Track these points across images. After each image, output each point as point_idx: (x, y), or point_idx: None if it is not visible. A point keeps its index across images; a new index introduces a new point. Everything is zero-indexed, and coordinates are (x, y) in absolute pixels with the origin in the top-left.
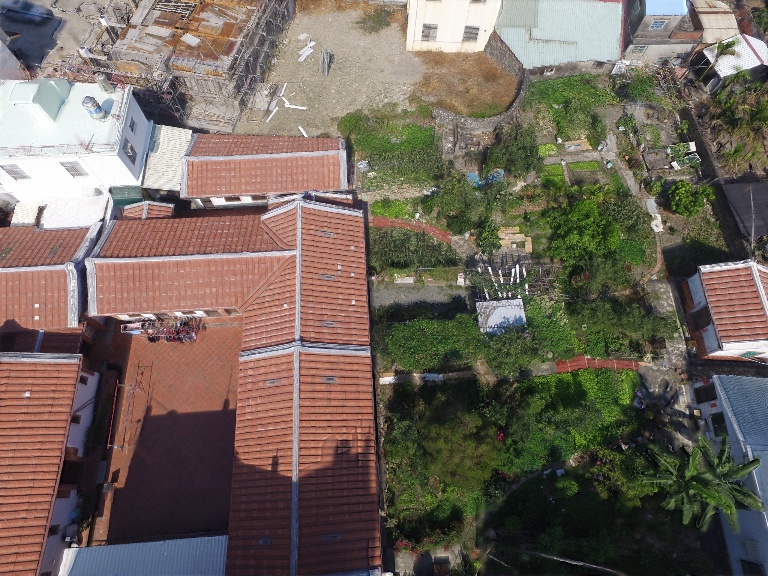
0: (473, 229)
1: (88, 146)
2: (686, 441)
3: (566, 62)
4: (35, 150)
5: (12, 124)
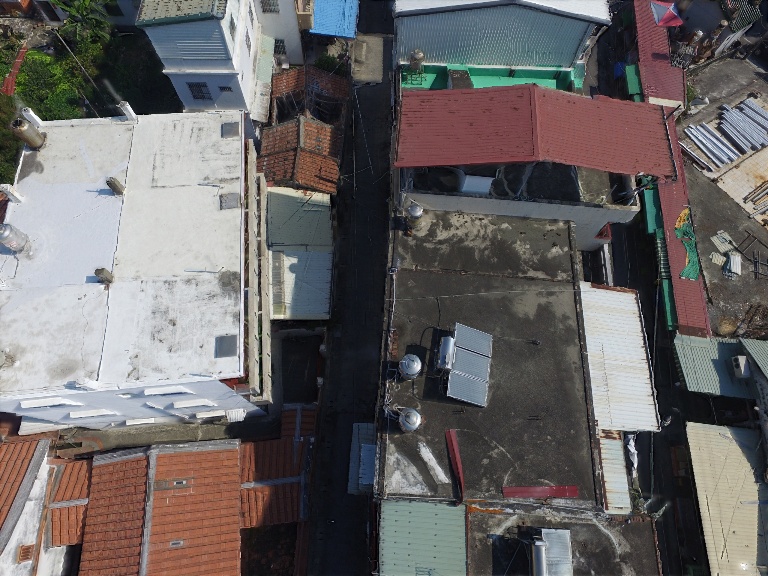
0: None
1: None
2: None
3: None
4: None
5: None
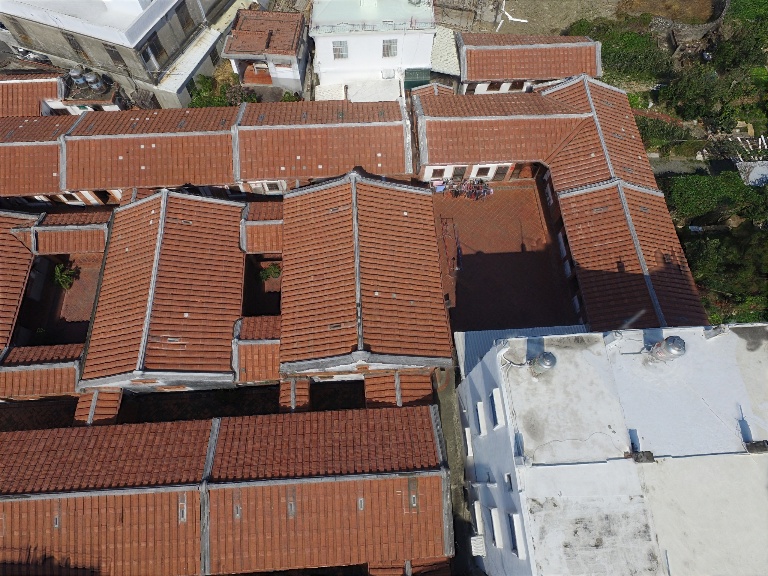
0: (699, 117)
1: (411, 25)
2: None
3: None
4: (368, 27)
5: (341, 8)
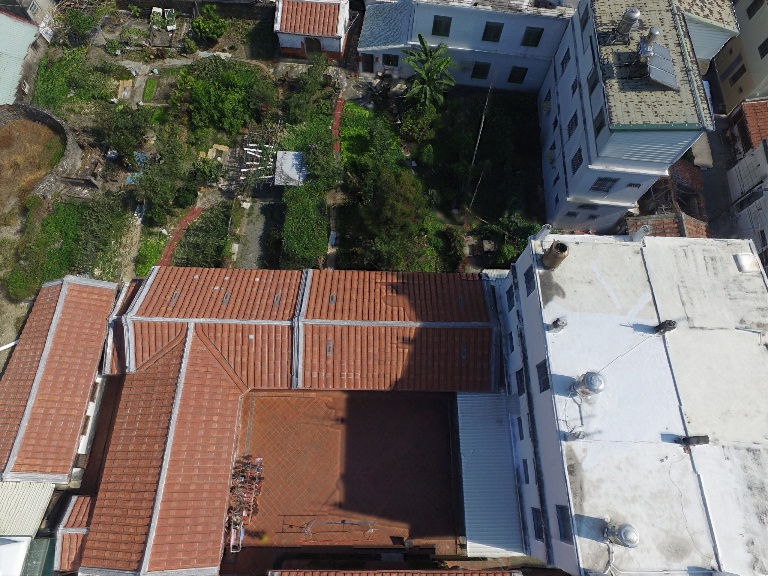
0: None
1: None
2: (398, 86)
3: (21, 68)
4: None
5: None
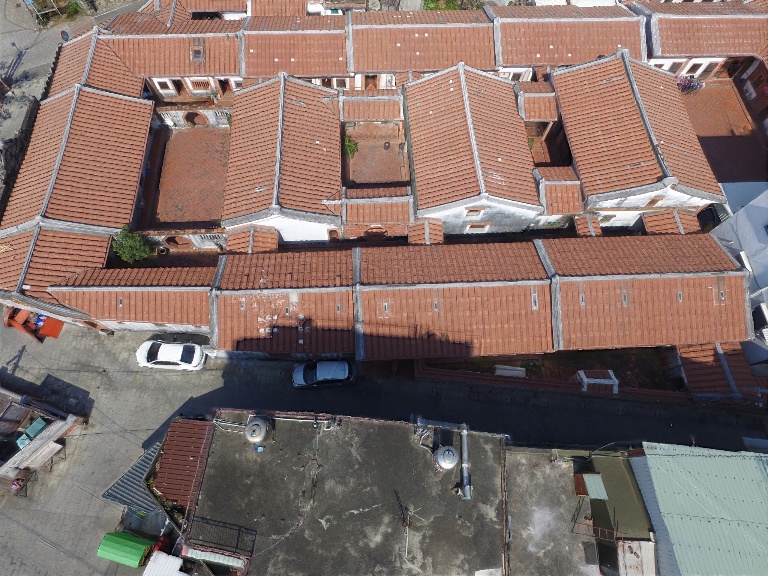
0: None
1: None
2: None
3: None
4: None
5: None
